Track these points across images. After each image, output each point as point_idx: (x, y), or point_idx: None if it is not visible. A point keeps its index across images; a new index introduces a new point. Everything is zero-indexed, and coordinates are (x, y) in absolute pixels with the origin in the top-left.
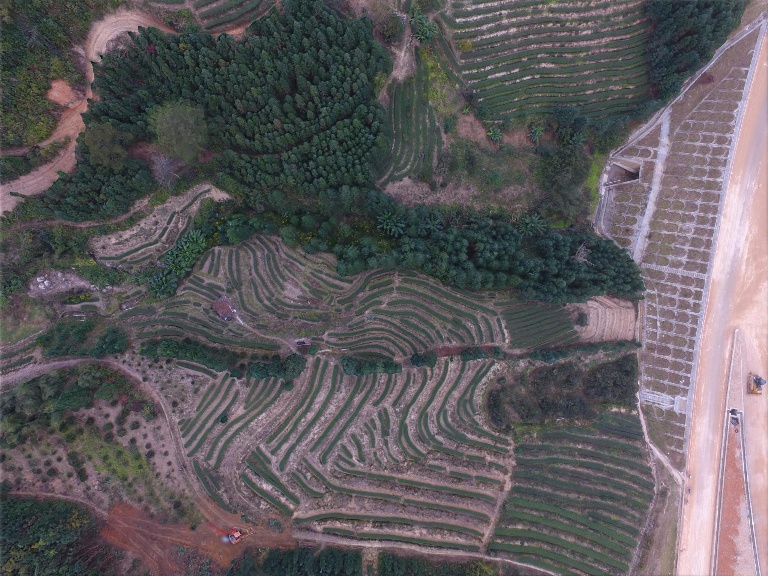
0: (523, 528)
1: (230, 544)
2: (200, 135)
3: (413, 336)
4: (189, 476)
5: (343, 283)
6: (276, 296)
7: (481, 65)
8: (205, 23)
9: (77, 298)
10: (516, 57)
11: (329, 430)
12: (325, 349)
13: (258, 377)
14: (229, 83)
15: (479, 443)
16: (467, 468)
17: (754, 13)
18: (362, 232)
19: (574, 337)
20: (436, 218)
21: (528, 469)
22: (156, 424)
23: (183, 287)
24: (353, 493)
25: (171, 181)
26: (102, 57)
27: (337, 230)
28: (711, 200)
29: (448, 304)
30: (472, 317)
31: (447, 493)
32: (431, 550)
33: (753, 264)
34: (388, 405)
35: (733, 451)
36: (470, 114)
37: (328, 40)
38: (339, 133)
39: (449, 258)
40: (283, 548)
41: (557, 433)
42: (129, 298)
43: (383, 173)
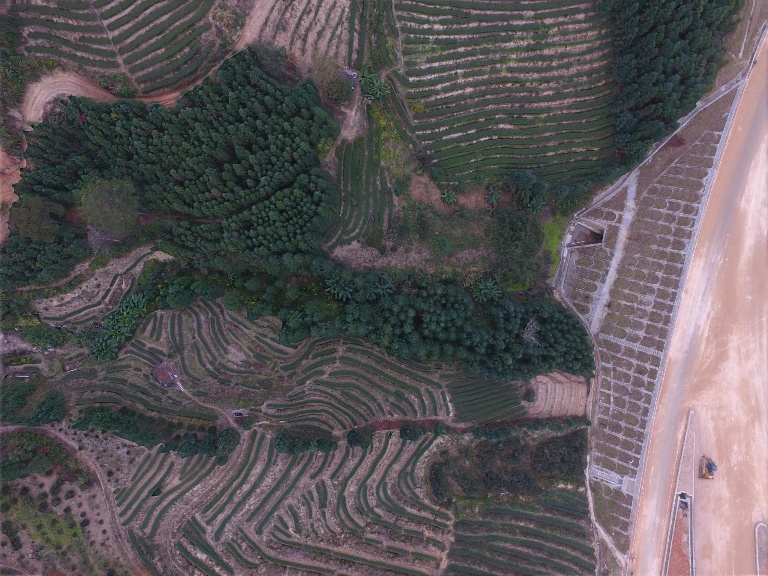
0: None
1: None
2: (136, 204)
3: (353, 409)
4: (124, 544)
5: (288, 348)
6: (219, 360)
7: (435, 126)
8: (142, 87)
9: (18, 361)
10: (472, 118)
11: (265, 501)
12: (262, 421)
13: (187, 456)
14: (162, 155)
15: (418, 517)
16: (404, 543)
17: (731, 73)
18: (310, 294)
19: (521, 412)
20: (386, 282)
21: (466, 547)
22: (92, 493)
23: (125, 351)
24: (287, 565)
25: (109, 248)
26: (33, 127)
27: (284, 292)
28: (673, 273)
29: (392, 375)
30: (415, 390)
31: (382, 568)
32: None
33: (713, 342)
34: (326, 478)
35: (680, 536)
36: (424, 174)
37: (267, 108)
38: (278, 204)
39: (393, 330)
40: None
41: (499, 509)
42: (72, 360)
43: (331, 237)
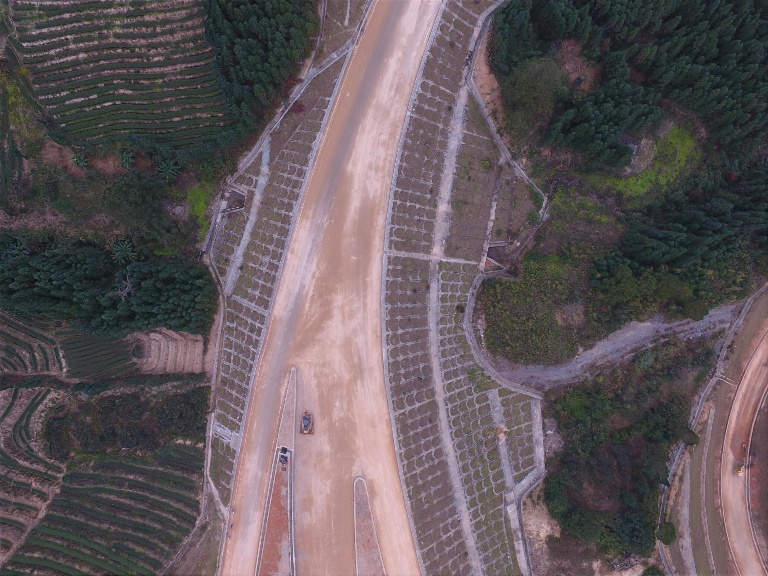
0: (39, 556)
1: None
2: None
3: None
4: None
5: None
6: None
7: (54, 91)
8: None
9: None
10: (89, 83)
11: None
12: None
13: None
14: None
15: (29, 469)
16: (8, 494)
17: (338, 40)
18: None
19: (133, 369)
20: (22, 243)
21: (68, 498)
22: None
23: None
24: None
25: None
26: None
27: None
28: (282, 235)
29: (6, 332)
30: (26, 346)
31: None
32: None
33: (318, 302)
34: None
35: (279, 489)
36: None
37: None
38: None
39: None
40: None
41: (111, 463)
42: None
43: None
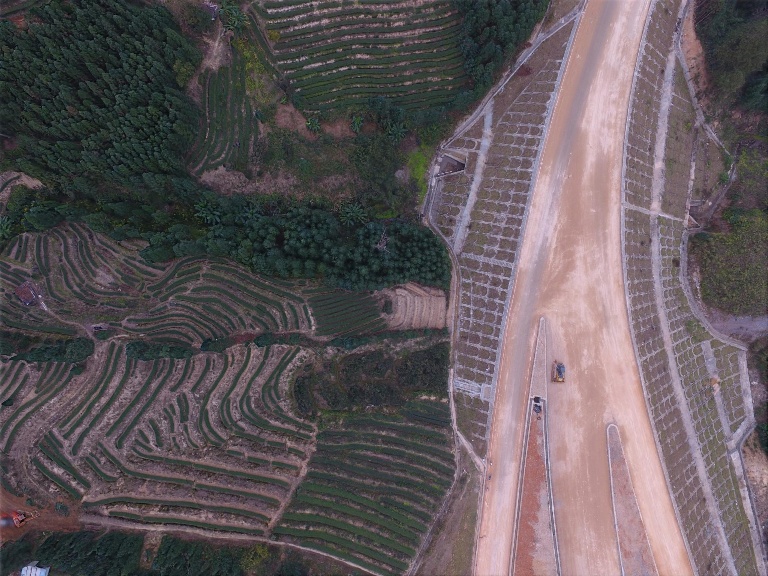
0: (311, 513)
1: (14, 527)
2: None
3: (214, 322)
4: None
5: (156, 270)
6: (86, 282)
7: (295, 55)
8: None
9: None
10: (329, 48)
11: (125, 415)
12: (122, 334)
13: (34, 360)
14: (13, 69)
15: (281, 429)
16: (265, 454)
17: (568, 6)
18: (181, 220)
19: (381, 325)
20: (254, 207)
21: (327, 455)
22: None
23: None
24: (147, 478)
25: None
26: None
27: None
28: (522, 190)
29: (254, 291)
30: (277, 304)
31: (242, 478)
32: (215, 534)
33: (561, 253)
34: (187, 390)
35: (535, 438)
36: (290, 104)
37: (119, 28)
38: (131, 120)
39: (252, 245)
40: (67, 531)
41: (362, 420)
42: None
43: (197, 161)
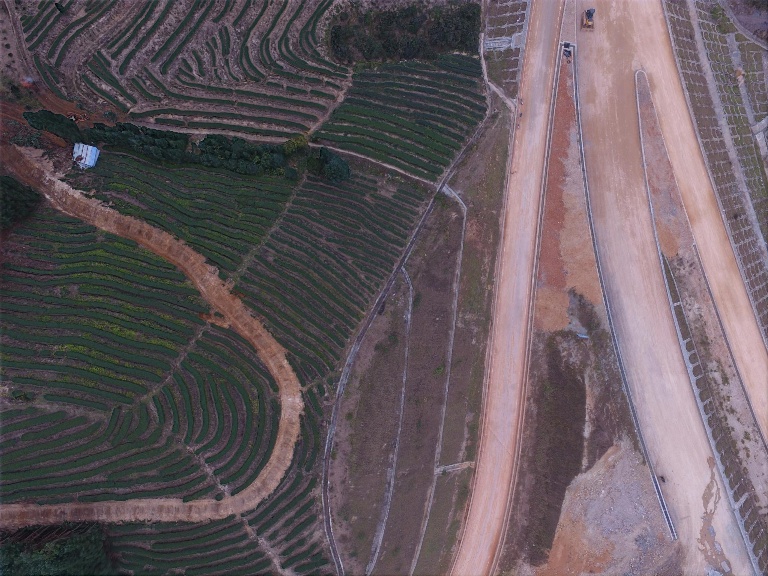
0: (349, 125)
1: None
2: None
3: None
4: (29, 68)
5: None
6: None
7: None
8: None
9: None
10: None
11: (170, 42)
12: None
13: None
14: None
15: (318, 69)
16: (303, 85)
17: None
18: None
19: None
20: None
21: (362, 88)
22: None
23: None
24: (190, 99)
25: None
26: None
27: None
28: None
29: None
30: None
31: None
32: (256, 137)
33: None
34: (229, 25)
35: (565, 80)
36: None
37: None
38: None
39: None
40: None
41: (396, 66)
42: None
43: None
